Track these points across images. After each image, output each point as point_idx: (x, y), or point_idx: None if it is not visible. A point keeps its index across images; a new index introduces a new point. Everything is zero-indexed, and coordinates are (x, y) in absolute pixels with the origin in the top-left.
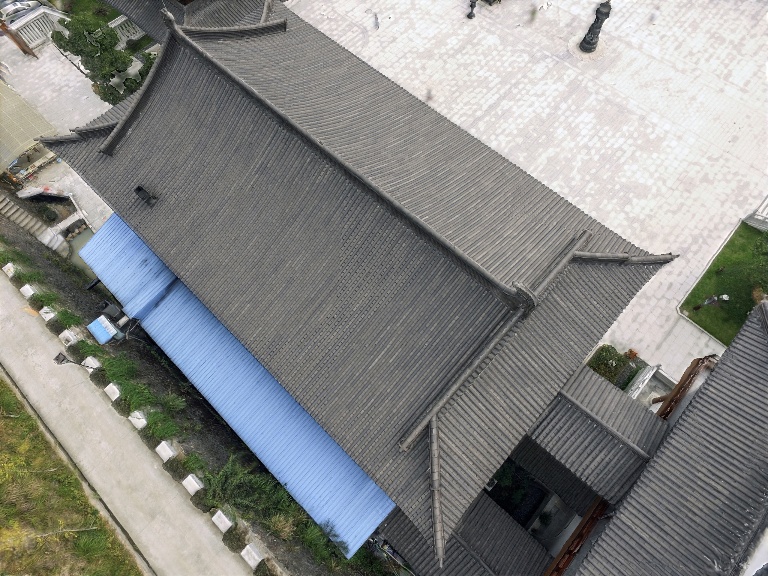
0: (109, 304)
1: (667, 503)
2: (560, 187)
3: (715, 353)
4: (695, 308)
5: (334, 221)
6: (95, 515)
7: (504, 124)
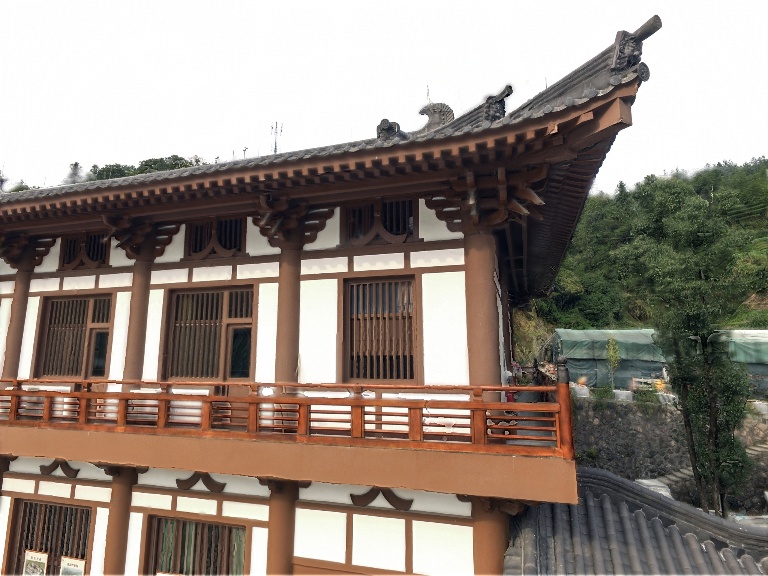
0: None
1: None
2: None
3: None
4: None
5: None
6: None
7: None
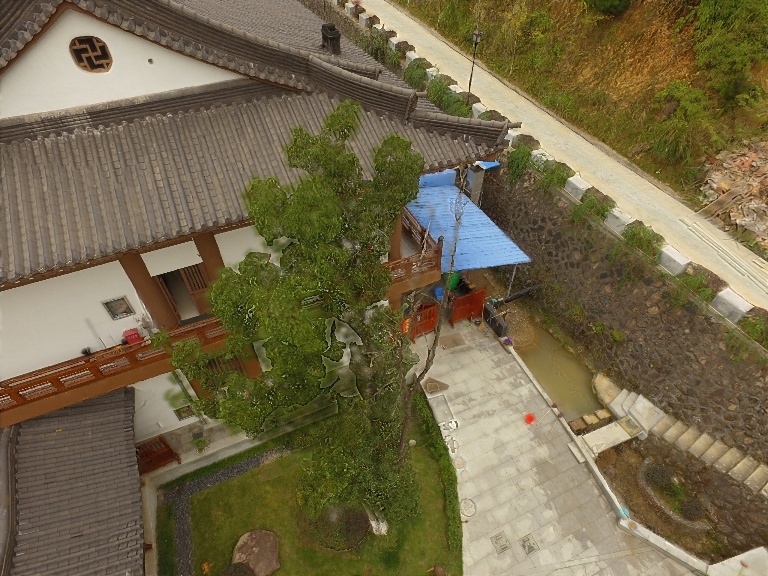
0: (469, 169)
1: None
2: None
3: None
4: None
5: None
6: None
7: None
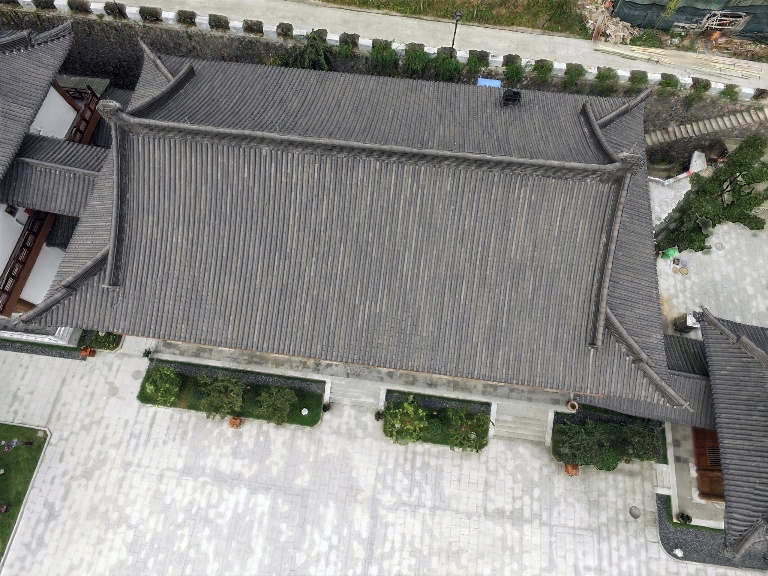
0: None
1: (0, 127)
2: (220, 514)
3: (7, 409)
4: (30, 443)
5: (324, 134)
6: (377, 6)
7: (333, 574)
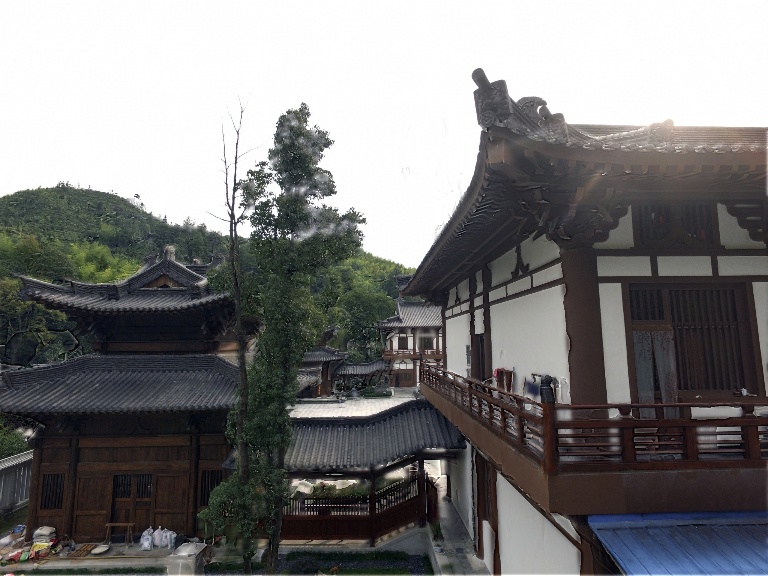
0: None
1: None
2: None
3: None
4: None
5: None
6: None
7: None
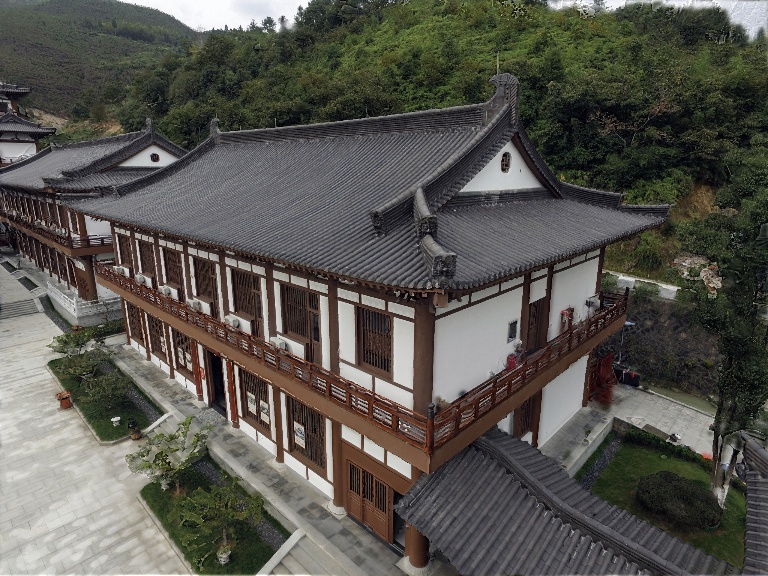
0: None
1: None
2: None
3: None
4: None
5: None
6: None
7: None
